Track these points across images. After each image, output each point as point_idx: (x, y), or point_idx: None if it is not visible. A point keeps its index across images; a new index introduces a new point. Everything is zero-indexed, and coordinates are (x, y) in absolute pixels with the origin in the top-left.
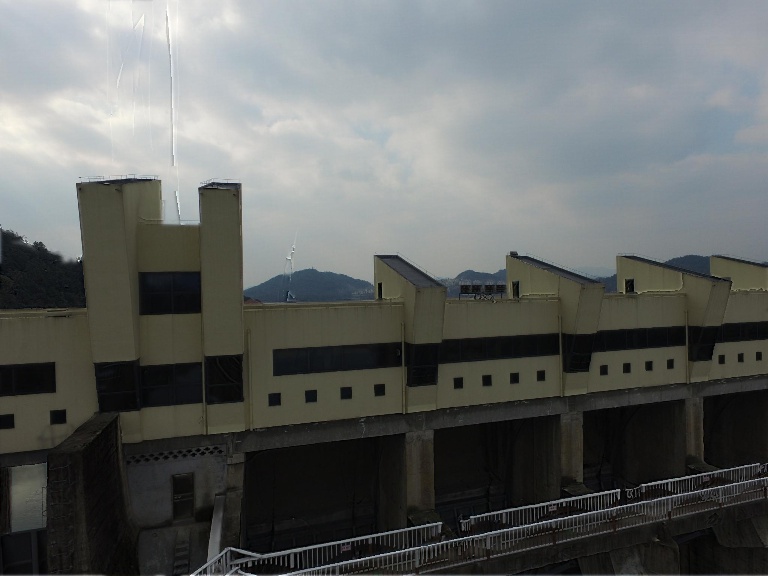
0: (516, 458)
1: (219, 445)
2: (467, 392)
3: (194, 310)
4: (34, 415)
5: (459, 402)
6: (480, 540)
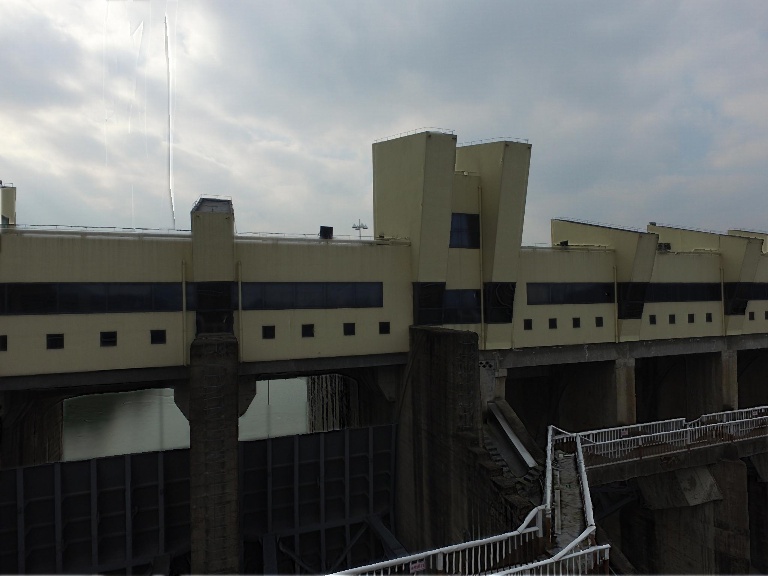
0: (662, 399)
1: (489, 360)
2: (658, 328)
3: (474, 246)
4: (368, 325)
5: (653, 336)
6: (726, 427)
